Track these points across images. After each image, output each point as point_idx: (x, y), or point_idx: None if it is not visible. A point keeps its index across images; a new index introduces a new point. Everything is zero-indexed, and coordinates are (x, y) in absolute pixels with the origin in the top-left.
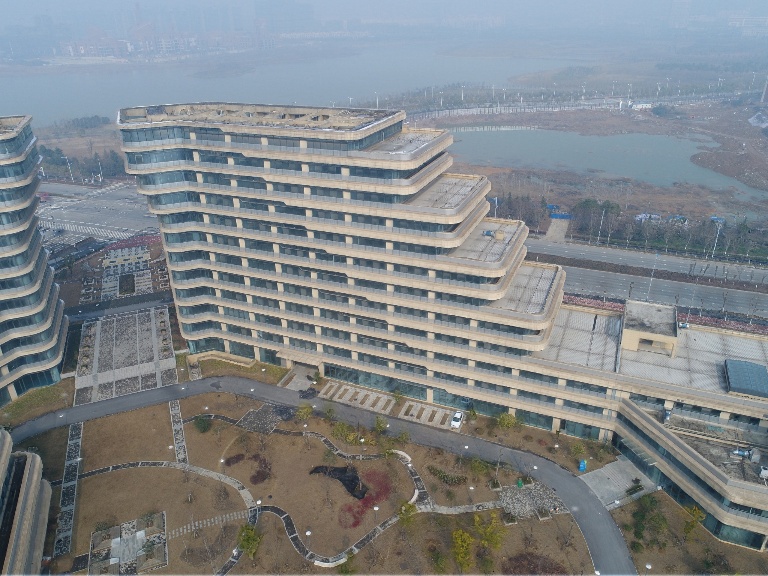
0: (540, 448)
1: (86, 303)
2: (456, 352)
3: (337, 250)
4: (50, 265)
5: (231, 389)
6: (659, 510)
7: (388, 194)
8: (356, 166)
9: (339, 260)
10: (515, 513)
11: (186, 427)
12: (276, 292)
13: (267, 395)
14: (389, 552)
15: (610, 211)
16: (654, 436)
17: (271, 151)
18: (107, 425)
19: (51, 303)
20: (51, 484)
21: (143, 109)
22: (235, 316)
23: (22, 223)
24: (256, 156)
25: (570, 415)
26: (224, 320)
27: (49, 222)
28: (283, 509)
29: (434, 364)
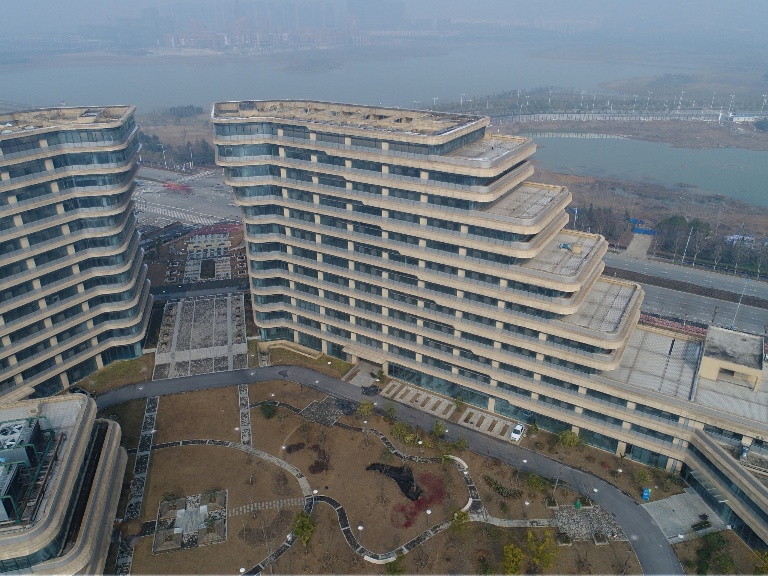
0: (602, 470)
1: (170, 284)
2: (522, 364)
3: (410, 252)
4: (140, 245)
5: (297, 379)
6: (726, 550)
7: (465, 200)
8: (435, 170)
9: (411, 262)
10: (570, 534)
11: (252, 411)
12: (347, 288)
13: (331, 388)
14: (438, 557)
15: (699, 230)
16: (727, 472)
17: (353, 151)
18: (181, 401)
19: (139, 282)
20: (127, 451)
21: (236, 104)
22: (306, 308)
23: (120, 206)
24: (339, 155)
25: (637, 440)
26: (295, 311)
27: (142, 205)
28: (338, 501)
29: (498, 374)
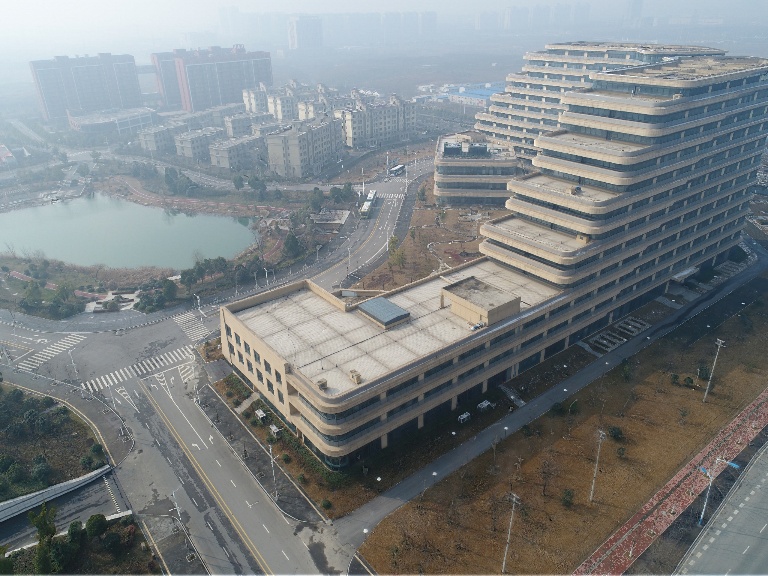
0: None
1: None
2: None
3: None
4: None
5: None
6: None
7: None
8: None
9: None
10: None
11: None
12: None
13: None
14: None
15: None
16: None
17: None
18: None
19: None
20: None
21: None
22: None
23: None
24: None
25: None
26: None
27: None
28: None
29: None
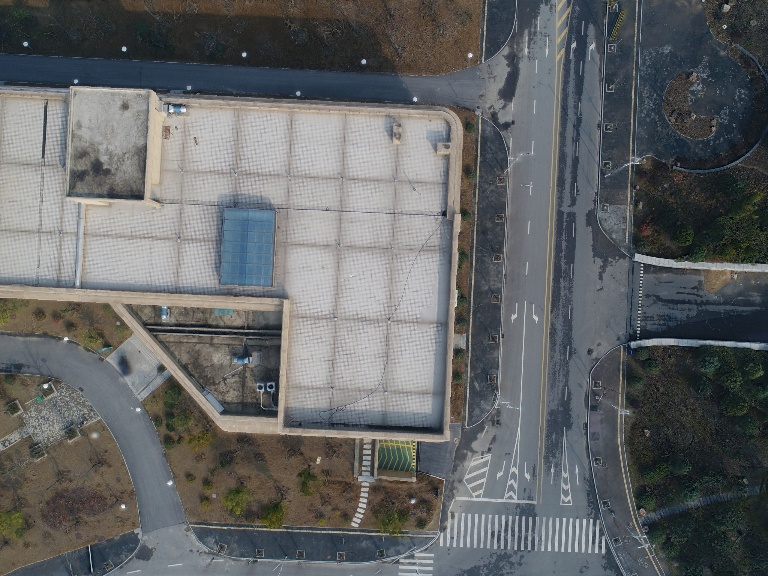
0: (57, 326)
1: None
2: None
3: None
4: None
5: None
6: None
7: None
8: None
9: None
10: (44, 439)
11: None
12: None
13: None
14: None
15: None
16: None
17: None
18: None
19: None
20: None
21: None
22: None
23: None
24: None
25: None
26: None
27: None
28: None
29: None
